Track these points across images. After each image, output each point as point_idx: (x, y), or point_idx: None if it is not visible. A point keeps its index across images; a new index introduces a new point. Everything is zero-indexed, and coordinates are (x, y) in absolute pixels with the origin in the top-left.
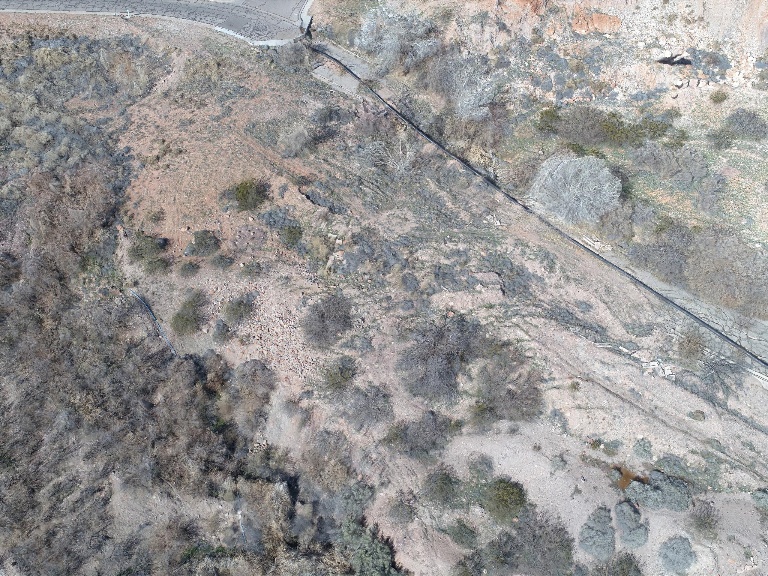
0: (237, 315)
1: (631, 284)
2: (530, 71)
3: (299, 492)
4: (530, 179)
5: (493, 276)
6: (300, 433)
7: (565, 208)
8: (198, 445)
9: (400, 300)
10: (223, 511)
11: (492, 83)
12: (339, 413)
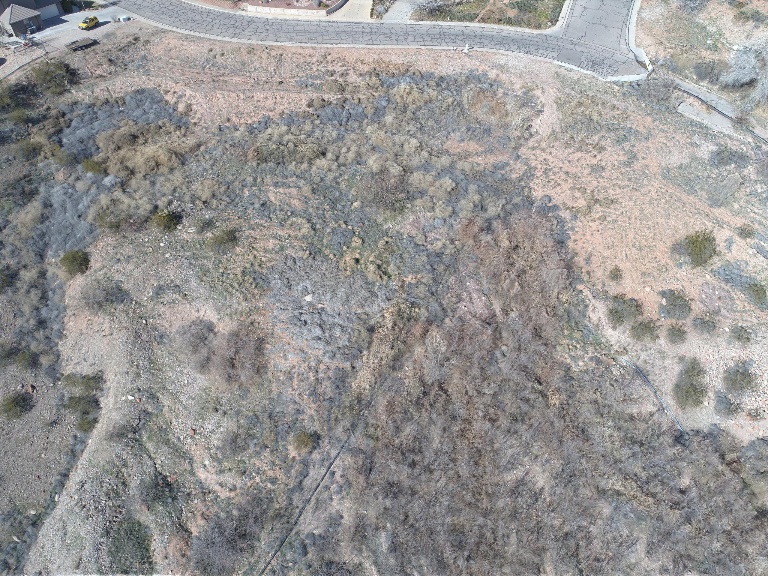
0: (736, 386)
1: None
2: None
3: None
4: None
5: None
6: None
7: None
8: None
9: None
10: None
11: None
12: None
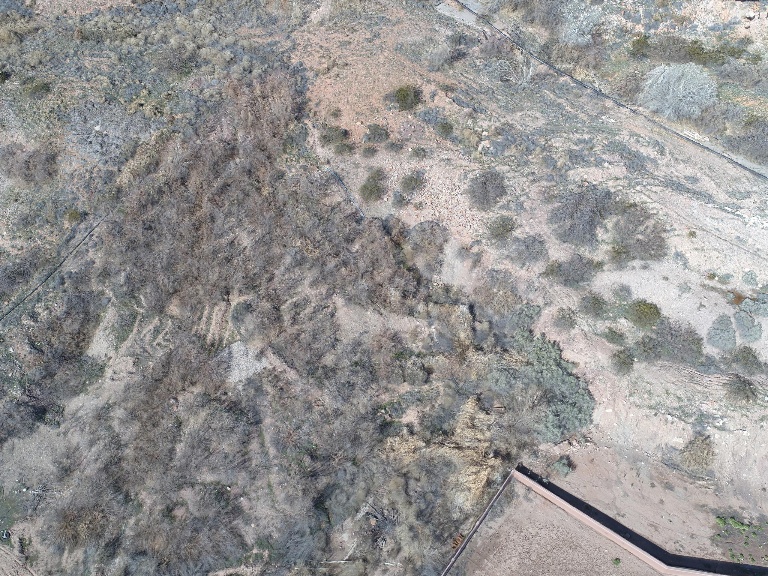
0: (410, 188)
1: (729, 164)
2: (622, 7)
3: (476, 315)
4: (632, 90)
5: (616, 157)
6: (471, 274)
7: (668, 108)
8: (396, 277)
9: (542, 175)
10: (420, 326)
11: (589, 17)
12: (504, 256)
